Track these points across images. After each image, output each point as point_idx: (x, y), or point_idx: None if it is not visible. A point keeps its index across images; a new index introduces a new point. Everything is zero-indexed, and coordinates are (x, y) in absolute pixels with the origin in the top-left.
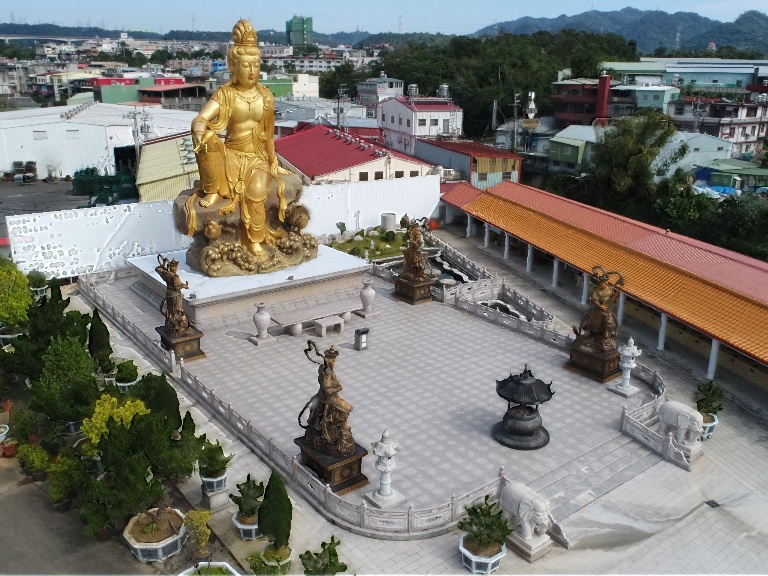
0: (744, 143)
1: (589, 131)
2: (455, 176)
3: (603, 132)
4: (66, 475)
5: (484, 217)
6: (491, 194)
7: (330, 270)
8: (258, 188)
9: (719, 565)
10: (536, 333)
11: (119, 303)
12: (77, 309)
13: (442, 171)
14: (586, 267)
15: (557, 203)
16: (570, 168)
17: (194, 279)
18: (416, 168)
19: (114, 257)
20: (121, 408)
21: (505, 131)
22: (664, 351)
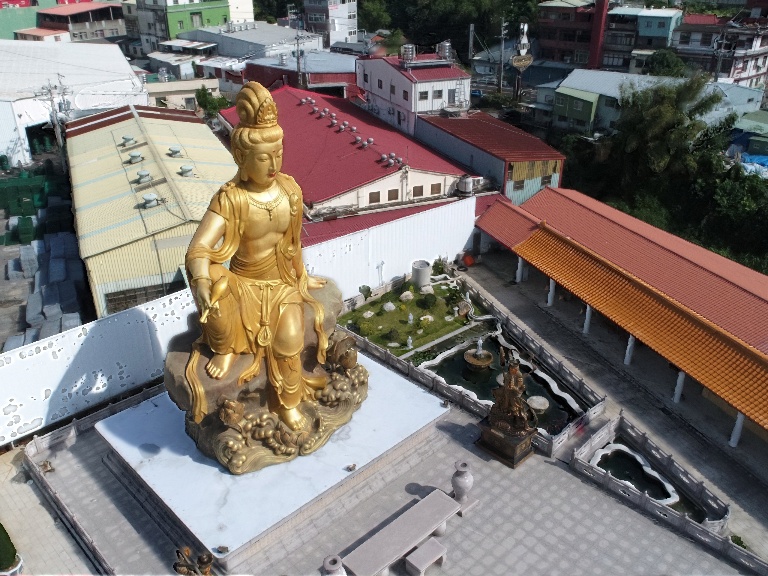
0: (755, 76)
1: (599, 79)
2: (484, 185)
3: (631, 93)
4: None
5: (552, 274)
6: (551, 232)
7: (398, 433)
8: (292, 337)
9: None
10: (714, 543)
11: (95, 507)
12: (32, 525)
13: (471, 183)
14: (751, 412)
15: (634, 242)
16: (579, 125)
17: (210, 484)
18: (438, 180)
19: (70, 399)
20: None
21: (484, 61)
22: None
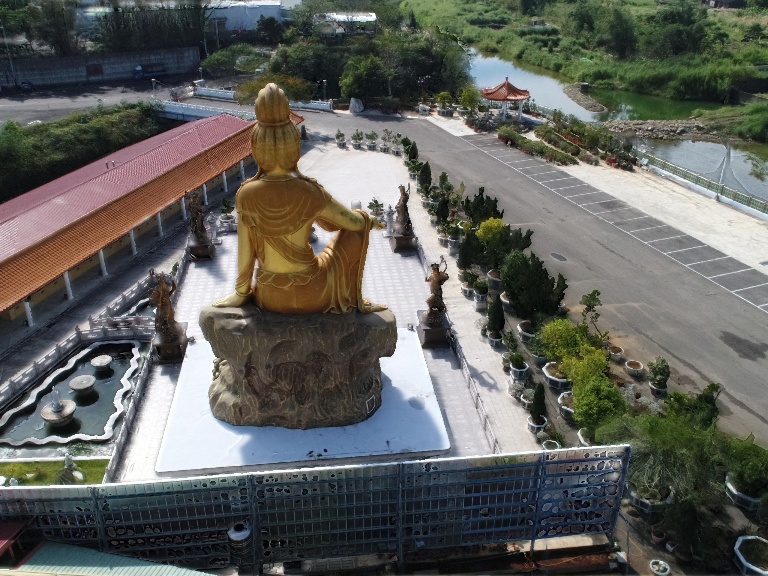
0: None
1: None
2: None
3: None
4: None
5: None
6: None
7: None
8: None
9: None
10: None
11: (469, 442)
12: None
13: None
14: (80, 258)
15: None
16: None
17: (393, 362)
18: None
19: (461, 529)
20: (491, 218)
21: None
22: (138, 252)
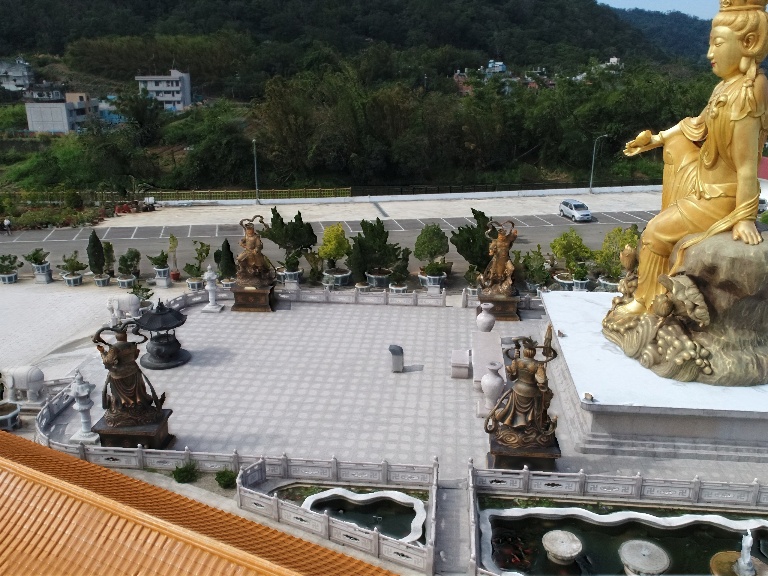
0: None
1: None
2: None
3: None
4: (349, 257)
5: None
6: None
7: (580, 365)
8: None
9: (6, 354)
10: None
11: None
12: None
13: None
14: (230, 516)
15: None
16: None
17: None
18: None
19: None
20: None
21: None
22: None
